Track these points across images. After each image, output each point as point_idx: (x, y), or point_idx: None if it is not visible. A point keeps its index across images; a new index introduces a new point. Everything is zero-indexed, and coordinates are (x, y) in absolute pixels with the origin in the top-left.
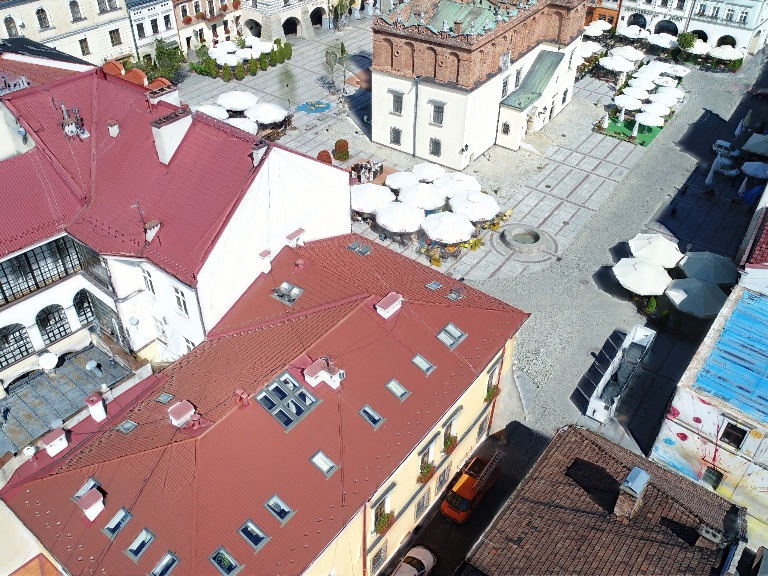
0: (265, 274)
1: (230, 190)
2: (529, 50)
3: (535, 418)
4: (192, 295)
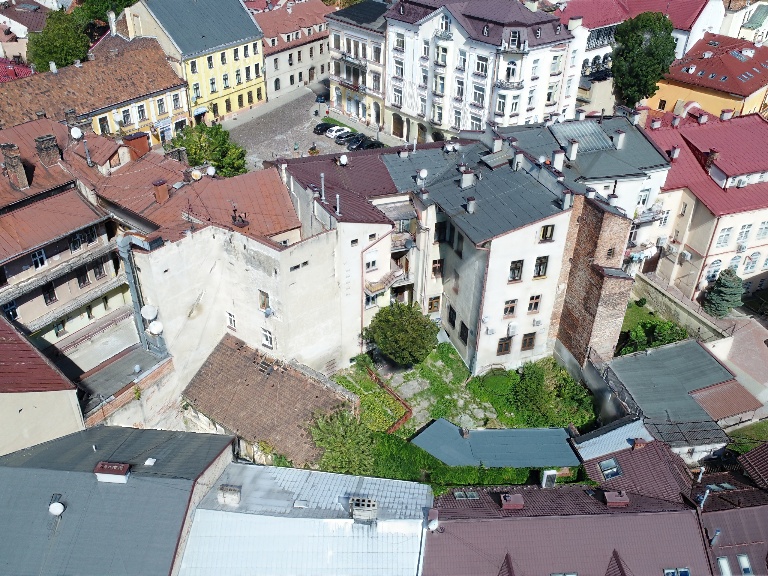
0: (702, 39)
1: (700, 2)
2: (756, 1)
3: None
4: (684, 38)
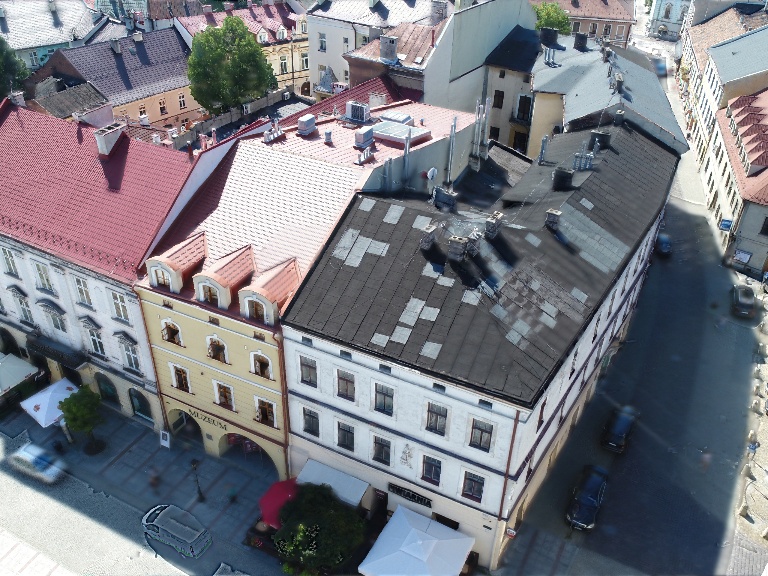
0: None
1: None
2: None
3: None
4: None
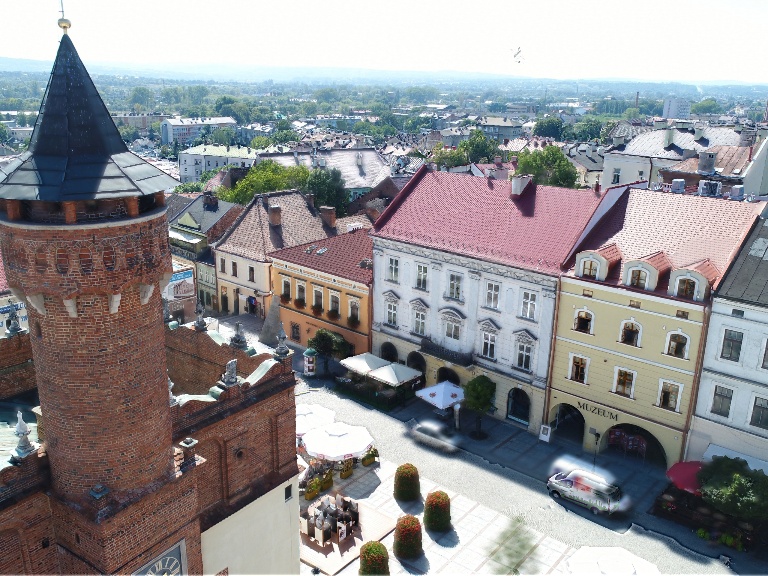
0: None
1: None
2: None
3: (254, 340)
4: None
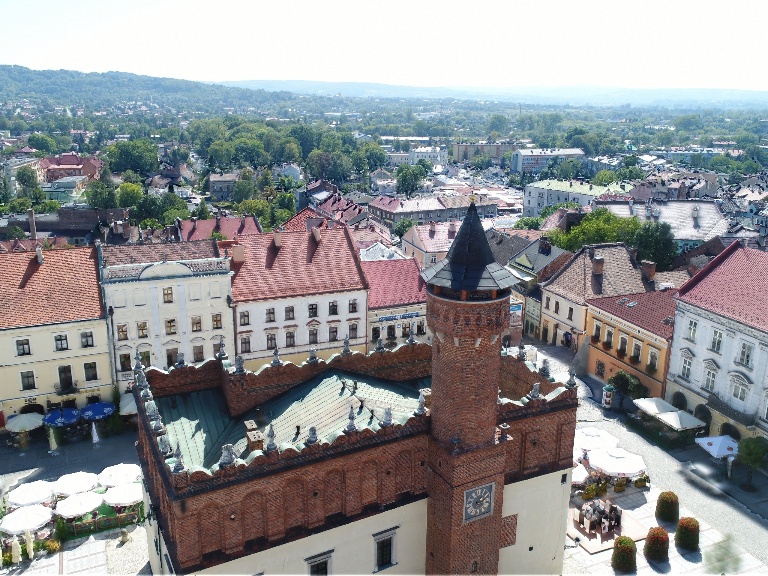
0: None
1: None
2: None
3: None
4: None
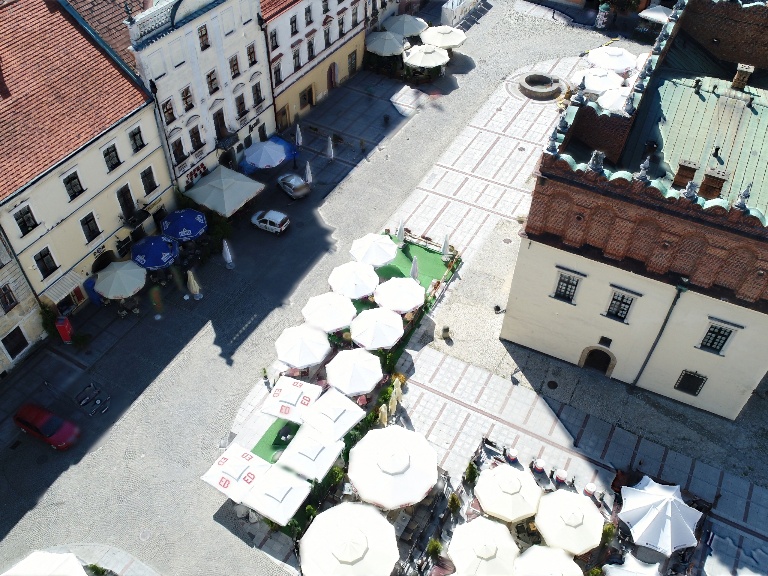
0: None
1: None
2: None
3: None
4: None
